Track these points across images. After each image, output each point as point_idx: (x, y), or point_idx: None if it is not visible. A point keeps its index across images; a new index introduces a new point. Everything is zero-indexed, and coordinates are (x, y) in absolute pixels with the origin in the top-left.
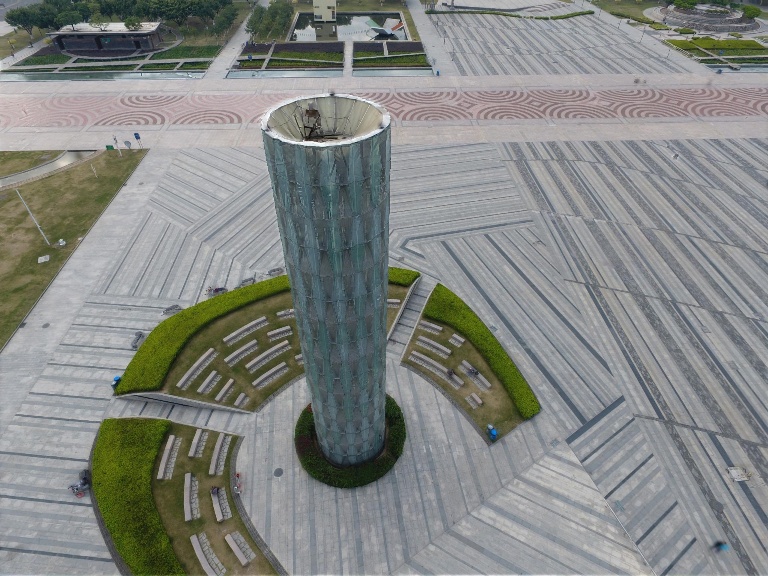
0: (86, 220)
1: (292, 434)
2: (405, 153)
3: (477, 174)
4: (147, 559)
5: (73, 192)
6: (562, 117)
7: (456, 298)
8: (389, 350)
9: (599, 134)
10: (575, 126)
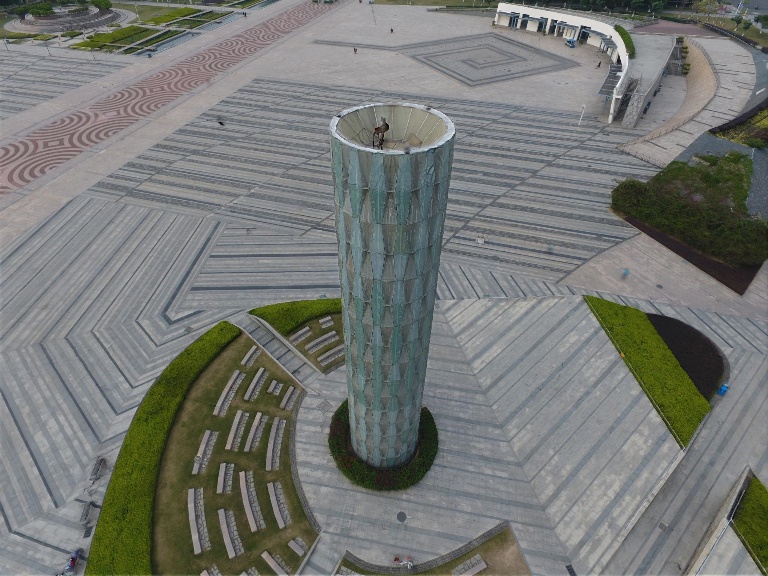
0: None
1: (364, 494)
2: (2, 264)
3: (116, 226)
4: None
5: None
6: (98, 141)
7: (277, 305)
8: (304, 379)
9: (150, 138)
10: (122, 142)
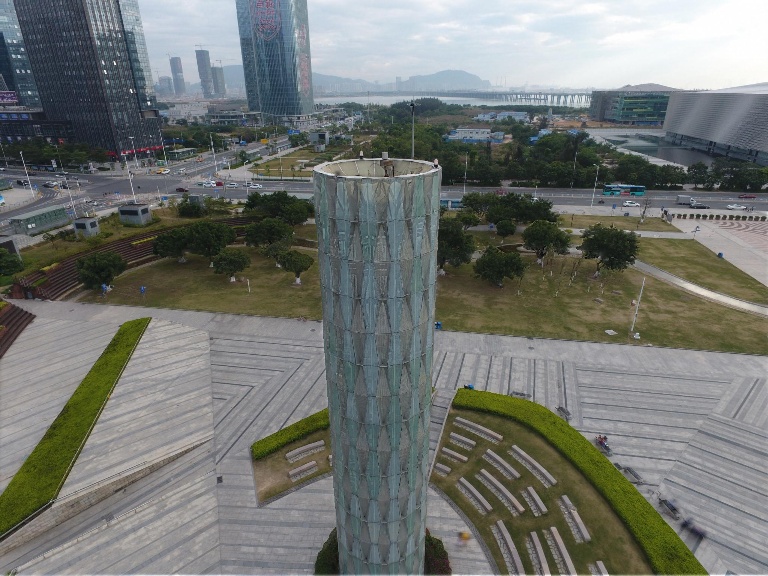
0: (682, 343)
1: None
2: None
3: None
4: (317, 418)
5: (725, 328)
6: None
7: None
8: None
9: None
10: None
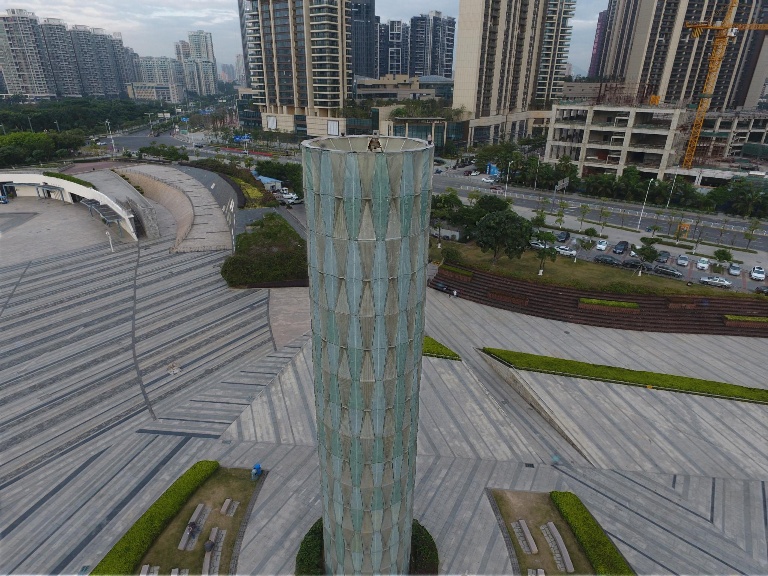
0: None
1: None
2: None
3: None
4: (620, 572)
5: None
6: None
7: None
8: None
9: None
10: None
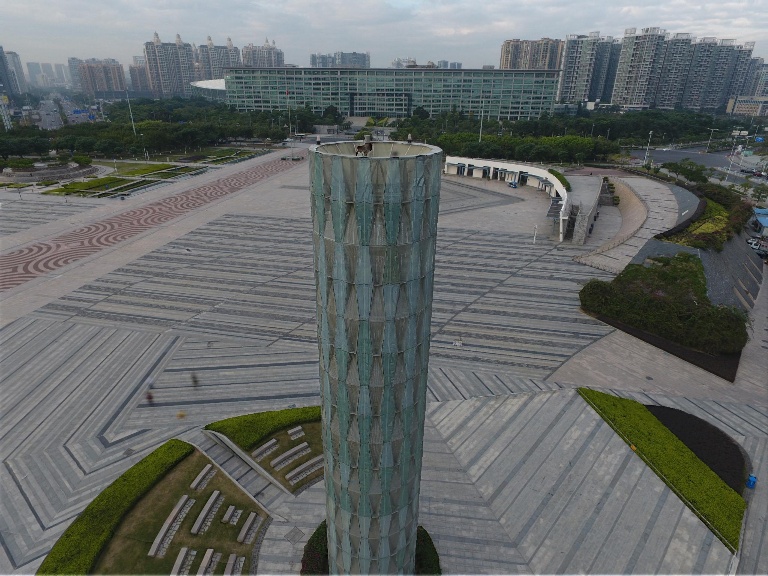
0: None
1: None
2: None
3: (59, 345)
4: None
5: None
6: (56, 268)
7: (239, 418)
8: (269, 502)
9: (112, 263)
10: (81, 268)
